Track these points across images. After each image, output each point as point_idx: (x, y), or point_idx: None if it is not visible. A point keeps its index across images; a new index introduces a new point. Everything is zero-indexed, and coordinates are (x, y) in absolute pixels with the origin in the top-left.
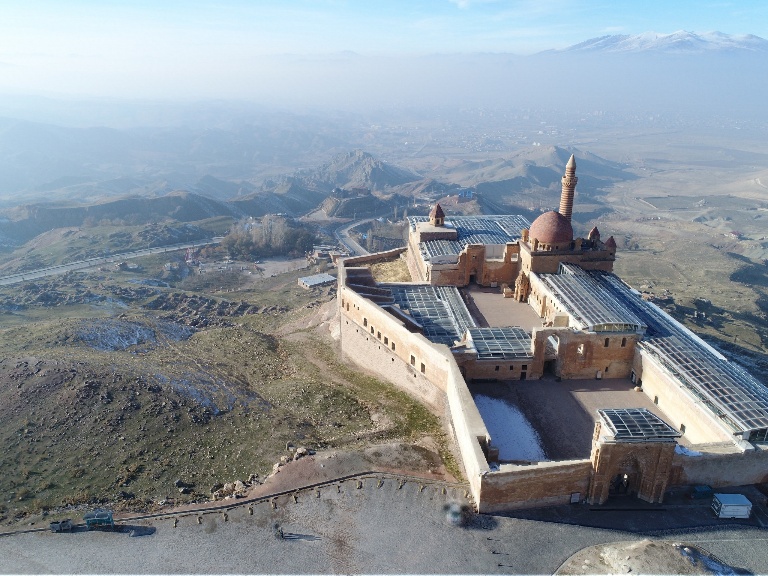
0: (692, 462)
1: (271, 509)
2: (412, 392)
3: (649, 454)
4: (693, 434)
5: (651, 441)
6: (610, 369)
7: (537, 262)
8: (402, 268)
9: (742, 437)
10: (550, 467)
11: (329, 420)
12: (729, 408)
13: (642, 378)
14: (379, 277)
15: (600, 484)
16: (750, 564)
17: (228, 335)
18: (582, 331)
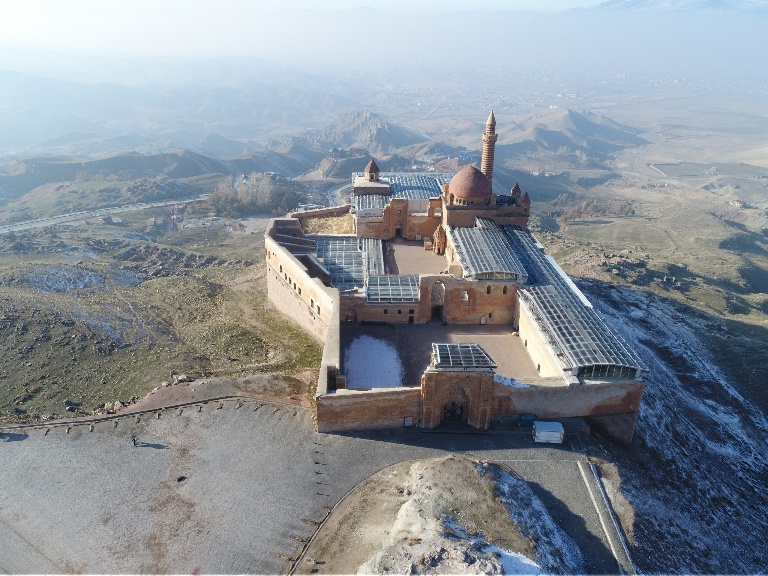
0: (519, 393)
1: (134, 423)
2: (313, 333)
3: (471, 383)
4: (544, 373)
5: (471, 371)
6: (493, 315)
7: (453, 216)
8: (347, 223)
9: (571, 373)
10: (381, 392)
11: (227, 355)
12: (568, 348)
13: (519, 324)
14: (323, 231)
15: (429, 409)
16: (544, 480)
17: (174, 283)
18: (465, 279)
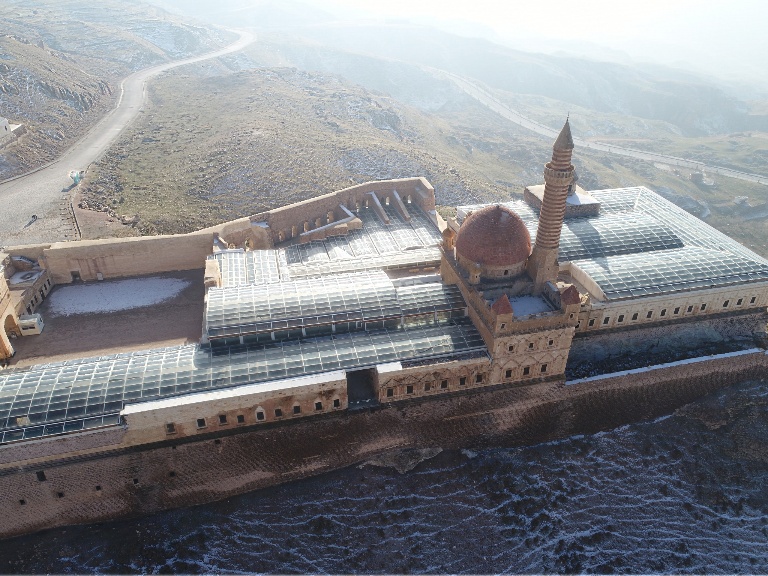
0: None
1: None
2: None
3: None
4: None
5: None
6: None
7: (444, 265)
8: None
9: None
10: None
11: None
12: None
13: None
14: None
15: None
16: None
17: None
18: None
